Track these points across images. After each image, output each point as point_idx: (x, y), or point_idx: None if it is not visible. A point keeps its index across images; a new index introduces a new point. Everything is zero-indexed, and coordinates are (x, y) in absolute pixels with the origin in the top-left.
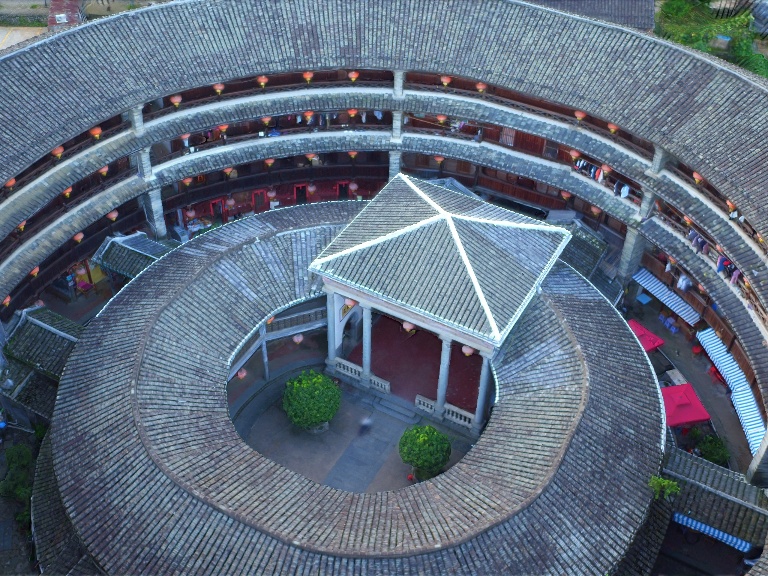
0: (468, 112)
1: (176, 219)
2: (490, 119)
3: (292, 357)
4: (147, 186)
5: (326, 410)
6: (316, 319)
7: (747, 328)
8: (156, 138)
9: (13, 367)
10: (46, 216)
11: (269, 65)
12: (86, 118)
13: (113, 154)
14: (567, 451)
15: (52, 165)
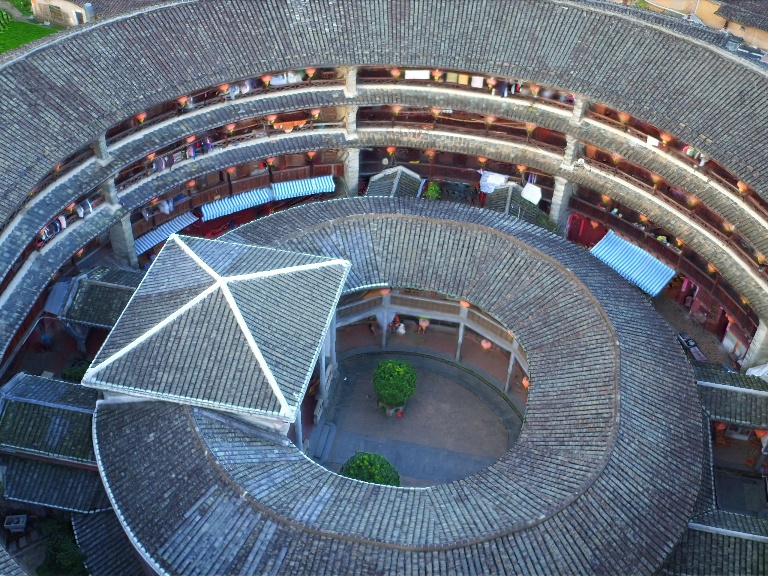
0: None
1: None
2: None
3: None
4: None
5: None
6: None
7: (257, 150)
8: None
9: None
10: None
11: None
12: None
13: None
14: None
15: None
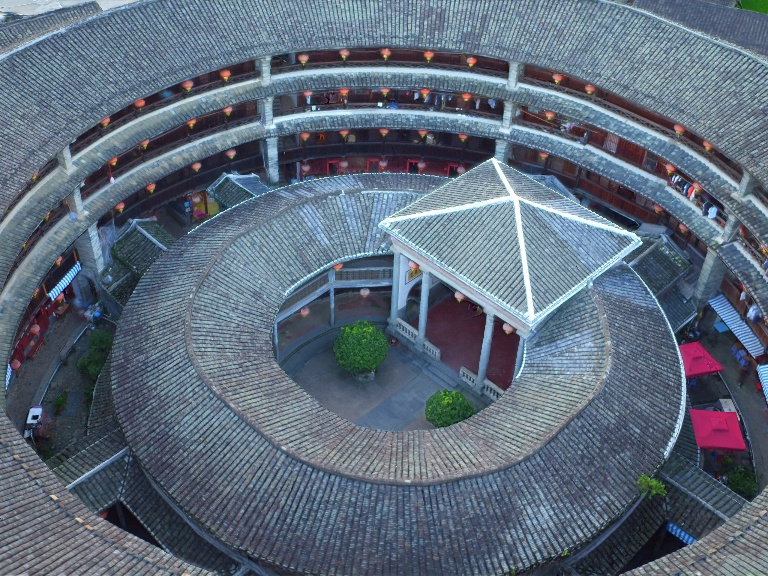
0: (574, 112)
1: (295, 172)
2: (594, 122)
3: (361, 311)
4: (266, 133)
5: (370, 359)
6: (384, 277)
7: None
8: (279, 90)
9: (116, 266)
10: (171, 142)
11: (393, 39)
12: (217, 60)
13: (238, 97)
14: (562, 431)
15: (182, 97)
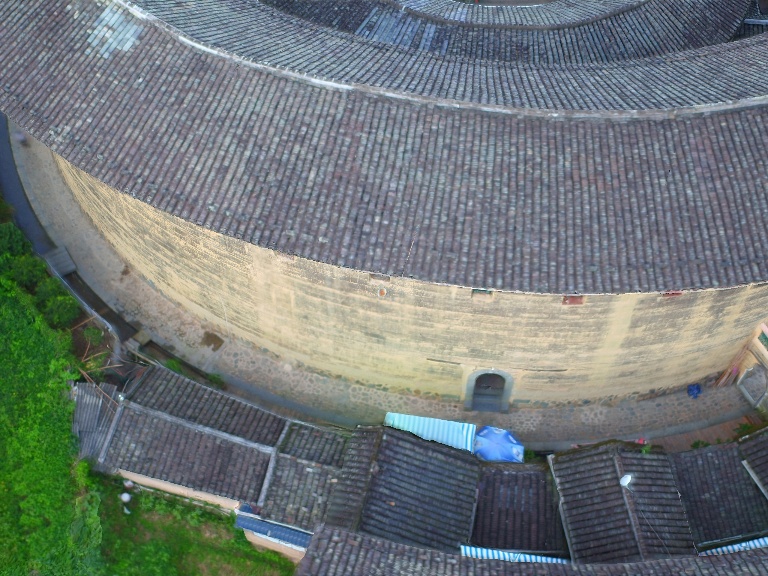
0: None
1: None
2: None
3: None
4: None
5: None
6: None
7: None
8: None
9: None
10: None
11: None
12: None
13: None
14: None
15: None
